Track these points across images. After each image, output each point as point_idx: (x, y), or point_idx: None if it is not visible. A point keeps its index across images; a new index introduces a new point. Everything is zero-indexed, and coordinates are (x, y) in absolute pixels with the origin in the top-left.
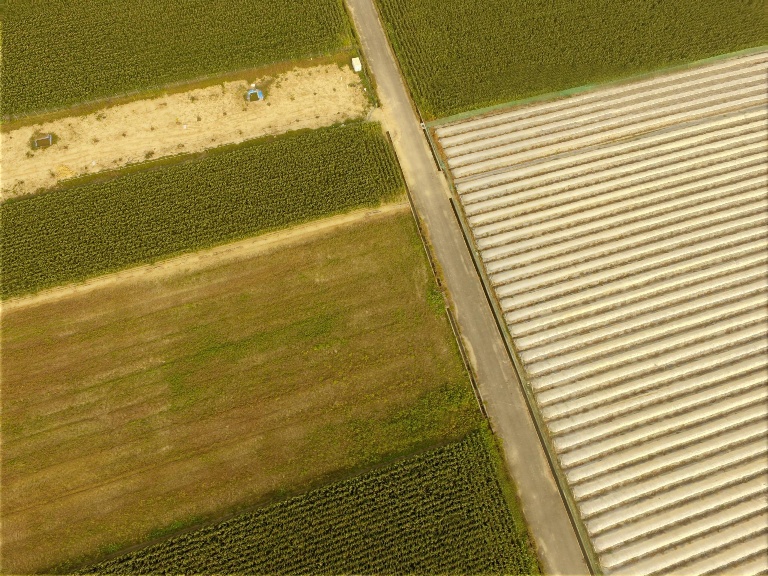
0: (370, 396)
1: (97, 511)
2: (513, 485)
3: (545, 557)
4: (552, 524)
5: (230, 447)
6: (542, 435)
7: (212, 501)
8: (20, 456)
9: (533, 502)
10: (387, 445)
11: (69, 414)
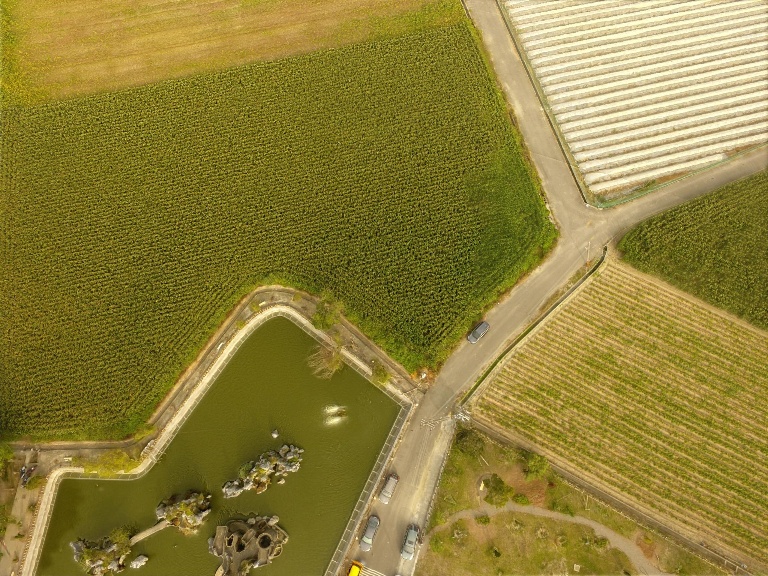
0: (386, 4)
1: (191, 57)
2: (488, 53)
3: (508, 92)
4: (514, 76)
5: (284, 28)
6: (511, 30)
7: (272, 55)
8: (135, 26)
9: (502, 64)
10: (398, 30)
11: (169, 5)
